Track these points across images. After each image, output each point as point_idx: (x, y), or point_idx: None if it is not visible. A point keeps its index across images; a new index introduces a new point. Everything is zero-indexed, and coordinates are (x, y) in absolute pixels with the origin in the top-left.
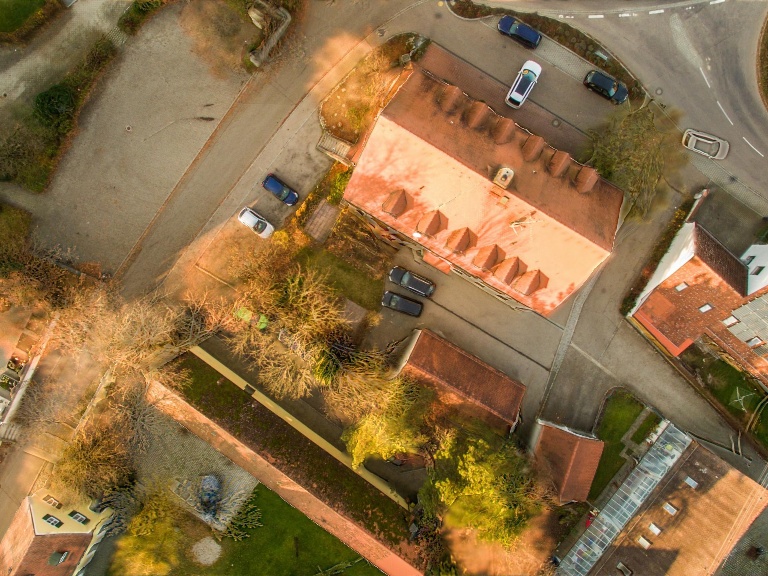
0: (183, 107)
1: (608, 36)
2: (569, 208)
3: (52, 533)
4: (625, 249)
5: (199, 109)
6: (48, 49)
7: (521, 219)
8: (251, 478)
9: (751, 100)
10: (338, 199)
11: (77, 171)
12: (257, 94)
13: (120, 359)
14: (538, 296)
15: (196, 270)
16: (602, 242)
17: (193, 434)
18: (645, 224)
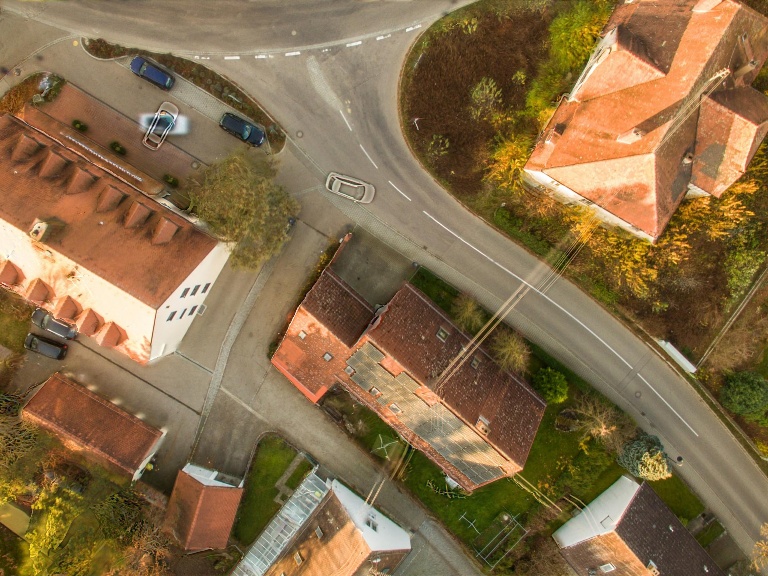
0: None
1: (245, 78)
2: (125, 262)
3: None
4: (271, 293)
5: None
6: None
7: (72, 273)
8: None
9: (395, 144)
10: None
11: None
12: None
13: None
14: (128, 346)
15: None
16: (148, 298)
17: None
18: (284, 269)
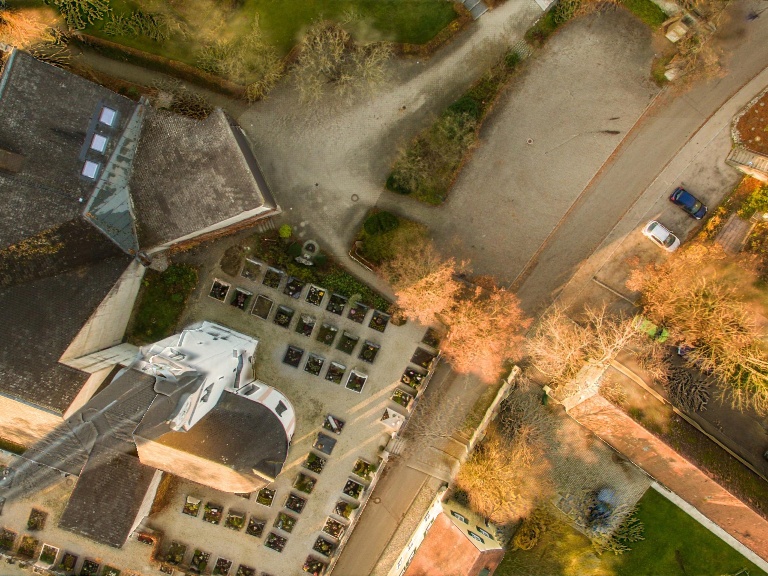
0: (588, 120)
1: None
2: None
3: (487, 549)
4: None
5: (604, 122)
6: (451, 61)
7: None
8: (634, 491)
9: None
10: (750, 213)
11: (475, 184)
12: (666, 108)
13: (558, 374)
14: None
15: (593, 283)
16: None
17: (578, 448)
18: None
